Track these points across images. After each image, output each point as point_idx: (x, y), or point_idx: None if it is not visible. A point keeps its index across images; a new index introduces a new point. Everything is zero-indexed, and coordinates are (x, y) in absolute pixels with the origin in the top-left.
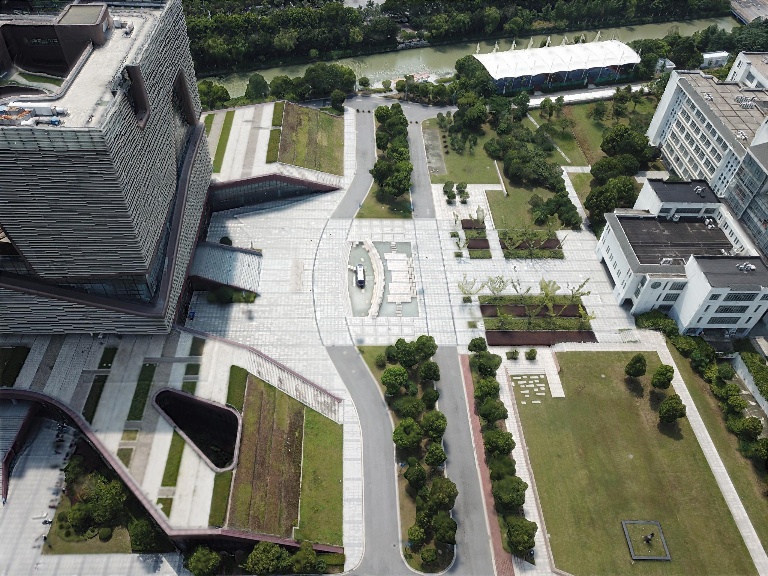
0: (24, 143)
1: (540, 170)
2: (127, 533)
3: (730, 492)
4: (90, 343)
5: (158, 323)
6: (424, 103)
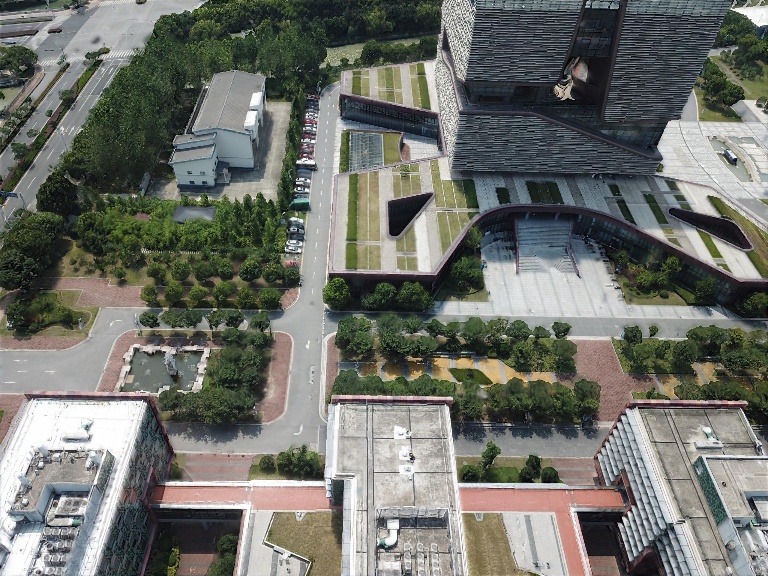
0: (675, 10)
1: None
2: (677, 295)
3: None
4: (595, 182)
5: (654, 165)
6: None
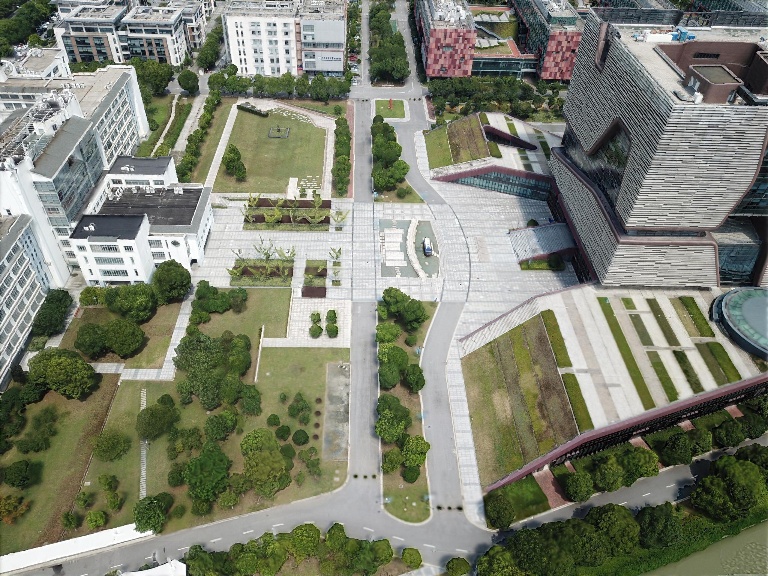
0: None
1: (210, 341)
2: None
3: (224, 140)
4: None
5: None
6: None
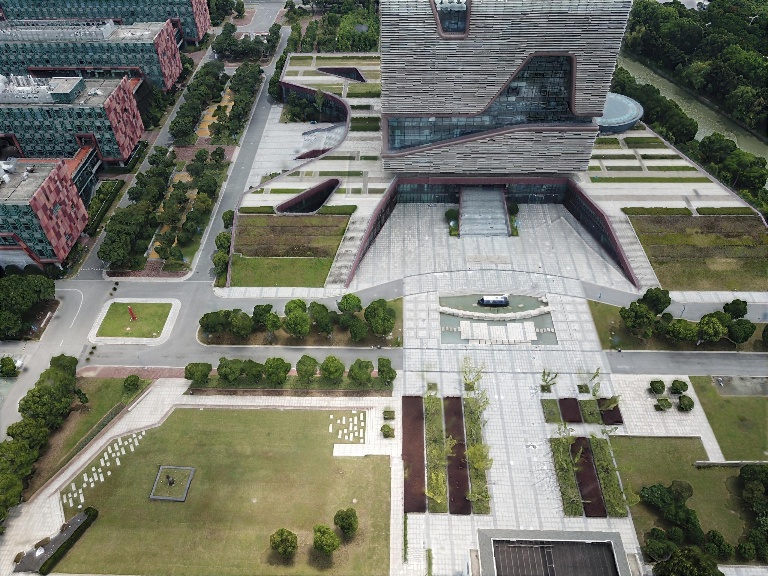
0: None
1: None
2: None
3: None
4: None
5: None
6: None
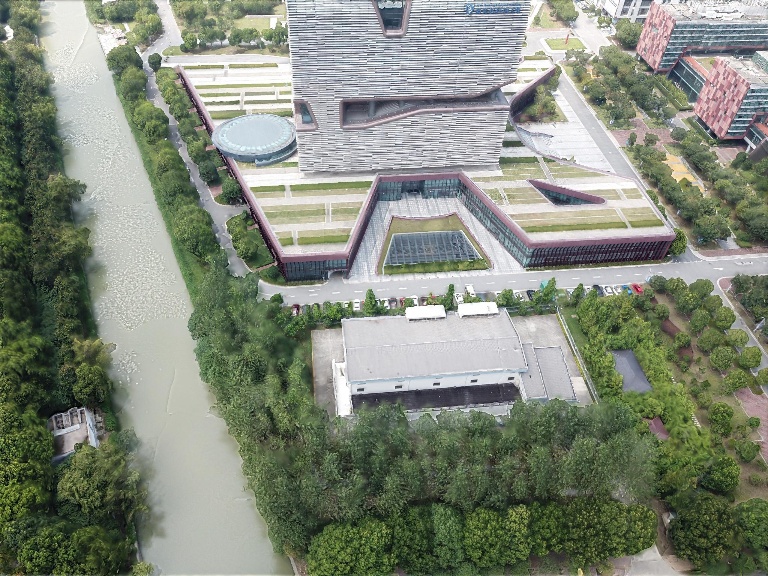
0: None
1: None
2: None
3: None
4: None
5: None
6: (158, 37)
